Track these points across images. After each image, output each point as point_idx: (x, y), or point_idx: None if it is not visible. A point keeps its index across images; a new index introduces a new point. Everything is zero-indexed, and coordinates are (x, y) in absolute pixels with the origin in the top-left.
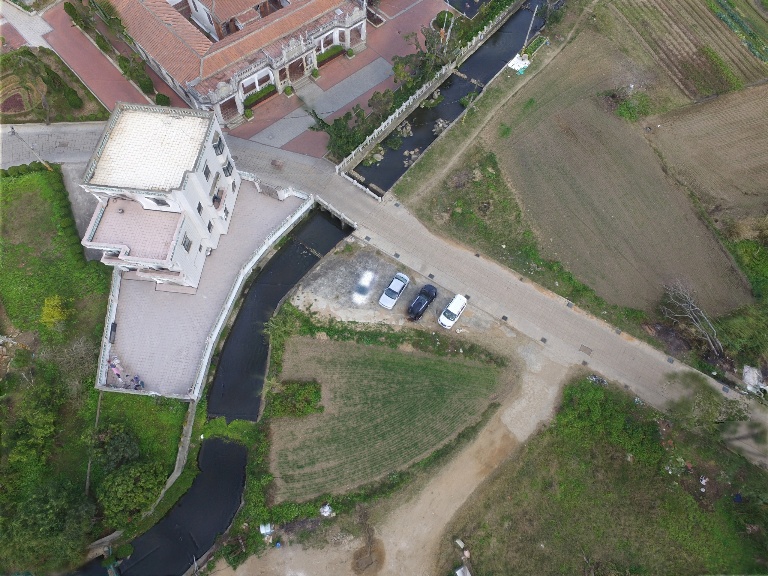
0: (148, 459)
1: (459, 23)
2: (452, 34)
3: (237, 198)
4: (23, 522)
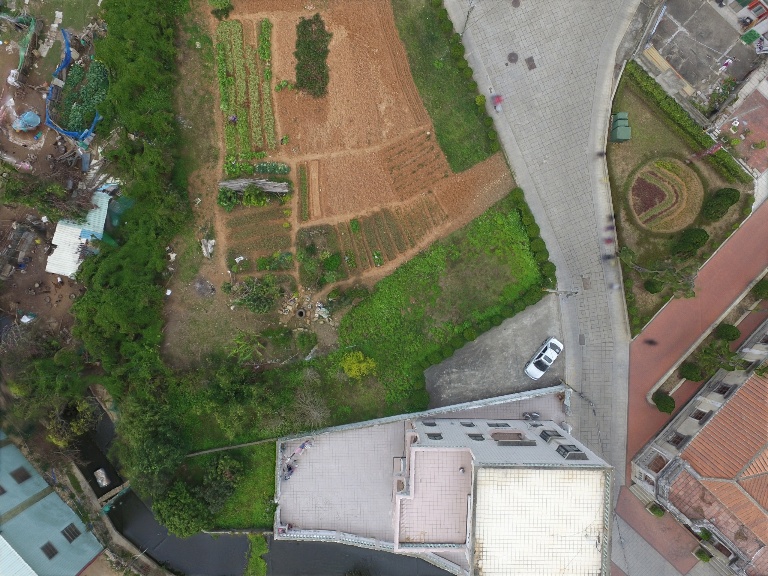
0: None
1: None
2: None
3: None
4: (151, 420)
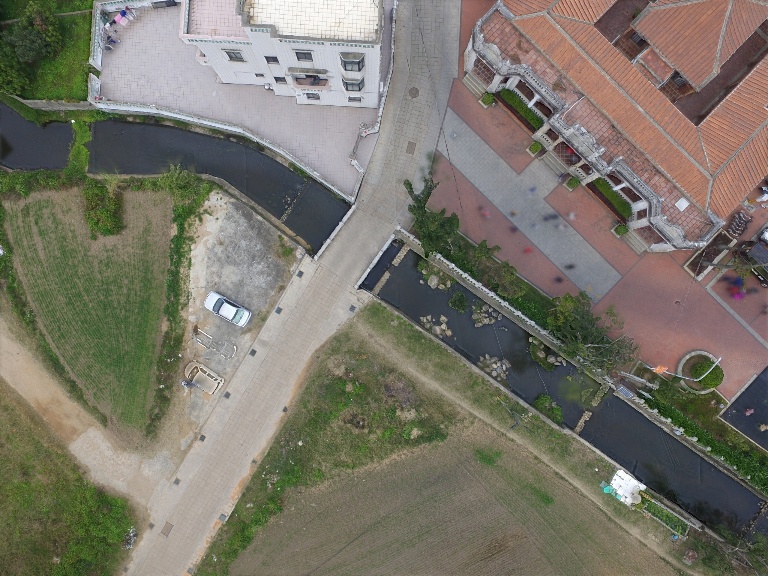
0: (37, 73)
1: (706, 397)
2: (659, 385)
3: (352, 107)
4: None
